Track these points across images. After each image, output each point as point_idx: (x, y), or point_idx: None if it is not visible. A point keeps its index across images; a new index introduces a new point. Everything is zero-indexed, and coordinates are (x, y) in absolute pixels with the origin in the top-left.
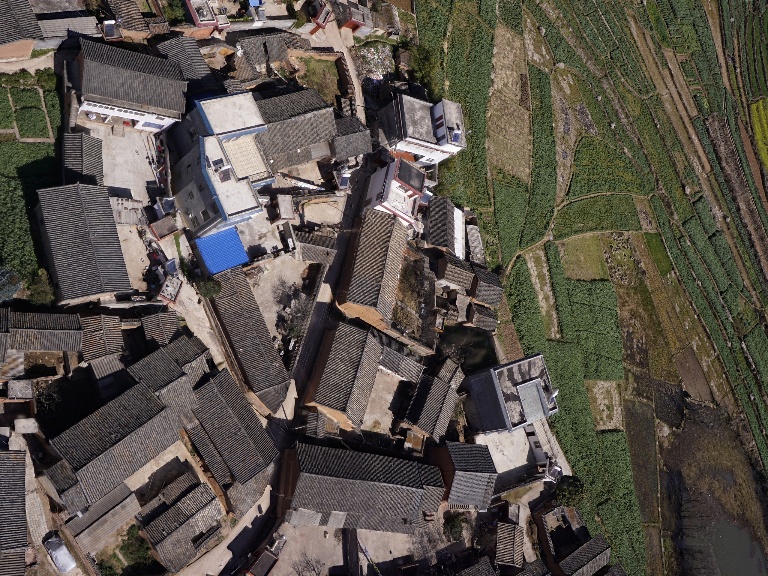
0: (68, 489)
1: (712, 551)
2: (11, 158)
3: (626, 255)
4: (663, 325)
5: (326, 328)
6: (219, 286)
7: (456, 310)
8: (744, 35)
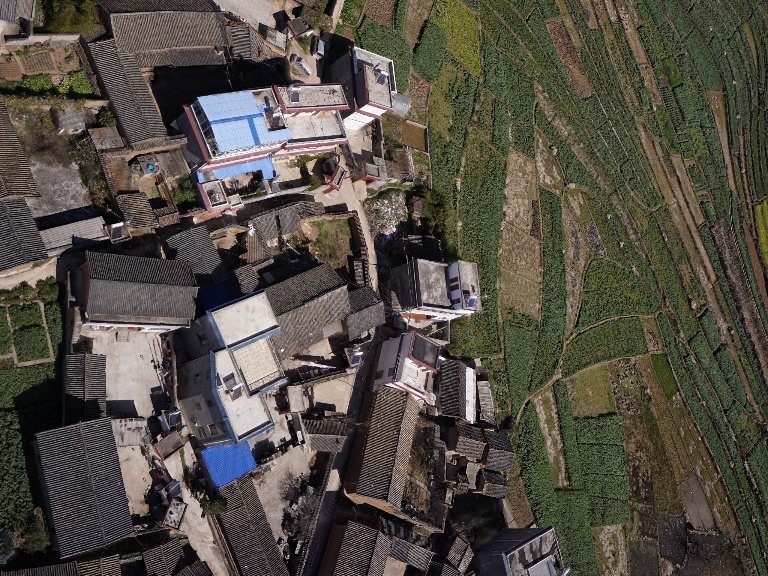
0: None
1: None
2: (8, 388)
3: (633, 382)
4: (668, 453)
5: (333, 520)
6: (225, 505)
7: (466, 480)
8: (749, 132)
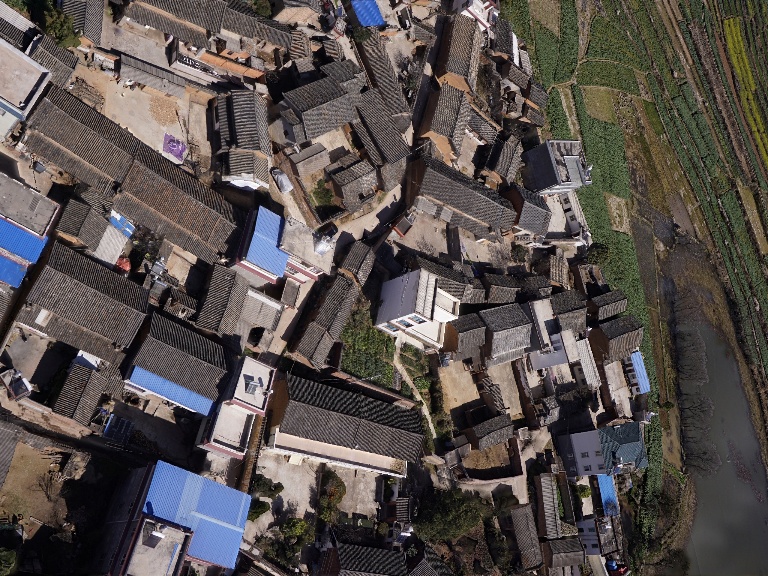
0: (296, 125)
1: (699, 333)
2: None
3: (630, 112)
4: (658, 171)
5: (430, 93)
6: None
7: (515, 104)
8: None
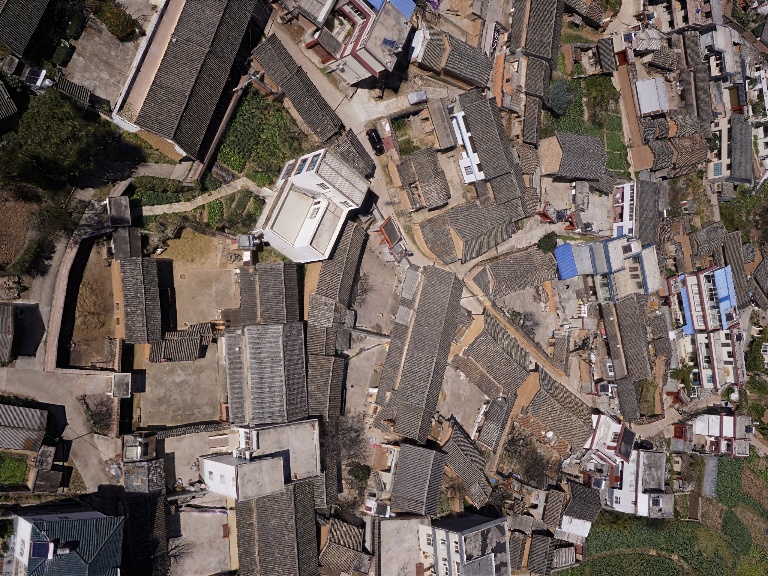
0: None
1: None
2: None
3: None
4: None
5: None
6: (555, 245)
7: (522, 512)
8: None
